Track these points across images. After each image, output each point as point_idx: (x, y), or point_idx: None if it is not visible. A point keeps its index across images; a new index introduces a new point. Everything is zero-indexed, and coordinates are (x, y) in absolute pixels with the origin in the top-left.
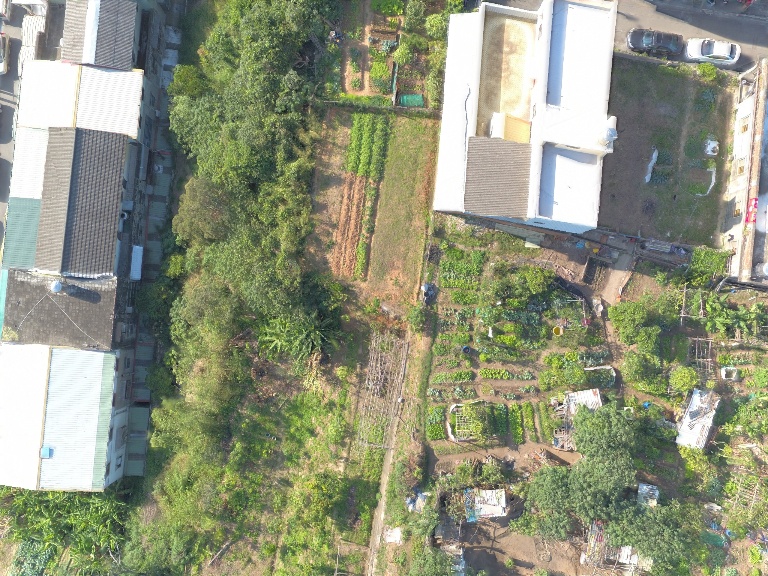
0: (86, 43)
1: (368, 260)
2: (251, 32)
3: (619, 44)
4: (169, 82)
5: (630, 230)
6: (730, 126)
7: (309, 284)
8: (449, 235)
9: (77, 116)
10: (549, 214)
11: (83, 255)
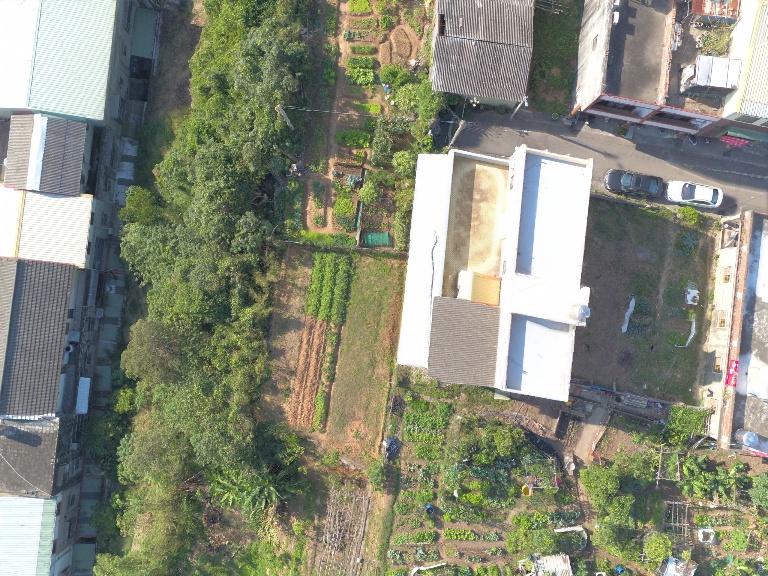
0: (31, 168)
1: (327, 410)
2: (205, 171)
3: (596, 184)
4: (124, 197)
5: (605, 382)
6: (711, 273)
7: (264, 434)
8: (414, 385)
9: (20, 245)
10: (517, 384)
11: (23, 395)
